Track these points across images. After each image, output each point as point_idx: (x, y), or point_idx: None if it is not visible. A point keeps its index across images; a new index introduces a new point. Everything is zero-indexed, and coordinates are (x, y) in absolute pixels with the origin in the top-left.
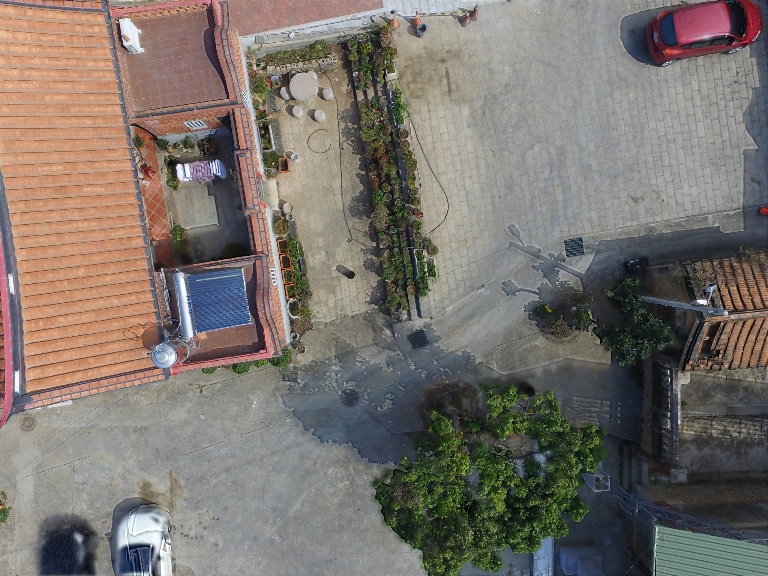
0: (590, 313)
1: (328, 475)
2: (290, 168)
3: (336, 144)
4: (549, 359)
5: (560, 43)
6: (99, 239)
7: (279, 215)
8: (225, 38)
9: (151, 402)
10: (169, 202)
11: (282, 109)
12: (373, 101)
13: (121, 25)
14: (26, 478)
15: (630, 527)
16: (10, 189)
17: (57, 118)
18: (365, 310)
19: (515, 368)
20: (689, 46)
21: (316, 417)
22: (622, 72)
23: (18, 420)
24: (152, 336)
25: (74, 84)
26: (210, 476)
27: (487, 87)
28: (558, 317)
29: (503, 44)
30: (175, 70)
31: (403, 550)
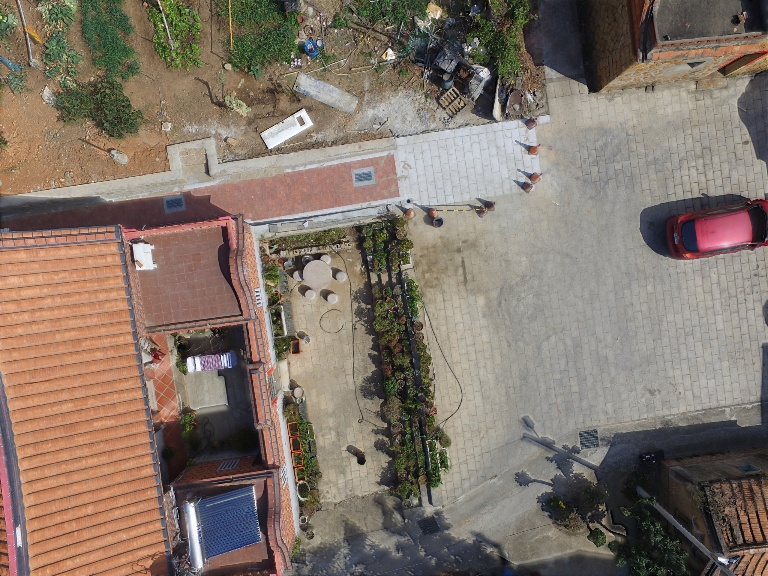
0: (604, 506)
1: None
2: (302, 348)
3: (349, 324)
4: (562, 550)
5: (578, 234)
6: (109, 473)
7: (290, 395)
8: (240, 264)
9: None
10: (178, 384)
11: (294, 289)
12: (387, 289)
13: (134, 250)
14: None
15: None
16: (19, 434)
17: (68, 355)
18: (375, 491)
19: (527, 558)
20: (710, 252)
21: None
22: (641, 264)
23: None
24: (161, 566)
25: (86, 318)
26: None
27: (503, 278)
28: (572, 510)
29: (520, 235)
30: (188, 285)
31: None
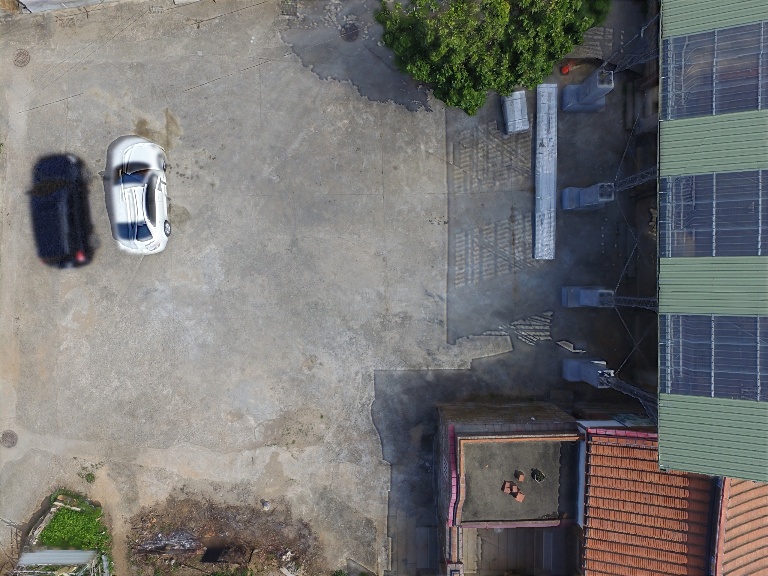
0: None
1: (327, 113)
2: None
3: None
4: None
5: None
6: None
7: None
8: None
9: (147, 38)
10: None
11: None
12: None
13: None
14: (19, 114)
15: (633, 170)
16: None
17: None
18: None
19: None
20: None
21: (315, 53)
22: None
23: (11, 55)
24: None
25: None
26: (207, 114)
27: None
28: None
29: None
30: None
31: (403, 191)
